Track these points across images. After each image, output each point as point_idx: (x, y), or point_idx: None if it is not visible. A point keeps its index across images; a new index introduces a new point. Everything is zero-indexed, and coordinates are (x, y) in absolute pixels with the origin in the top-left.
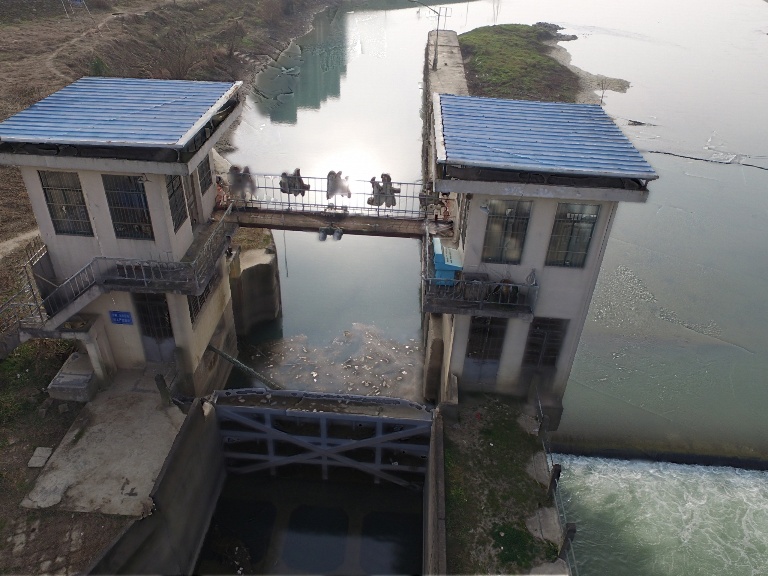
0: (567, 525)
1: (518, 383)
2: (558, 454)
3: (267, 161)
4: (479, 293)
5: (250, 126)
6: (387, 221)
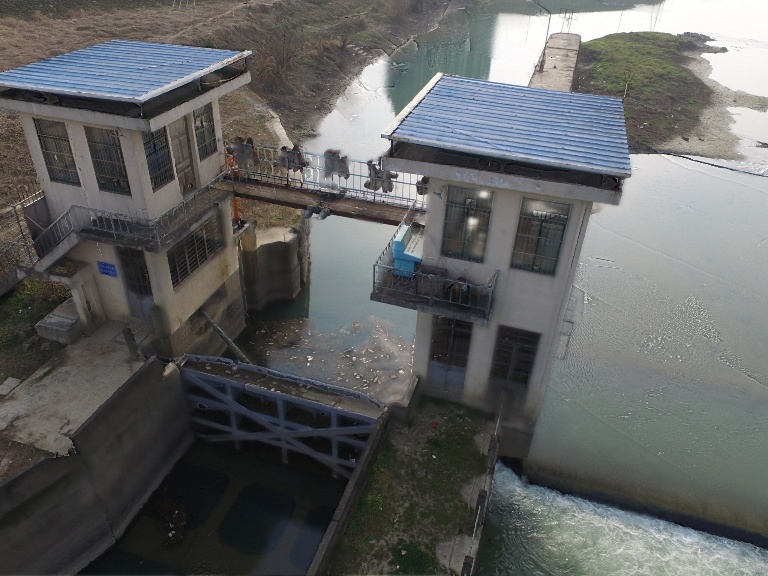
0: (465, 557)
1: (486, 397)
2: (542, 487)
3: (345, 149)
4: (433, 288)
5: (341, 115)
6: (381, 207)
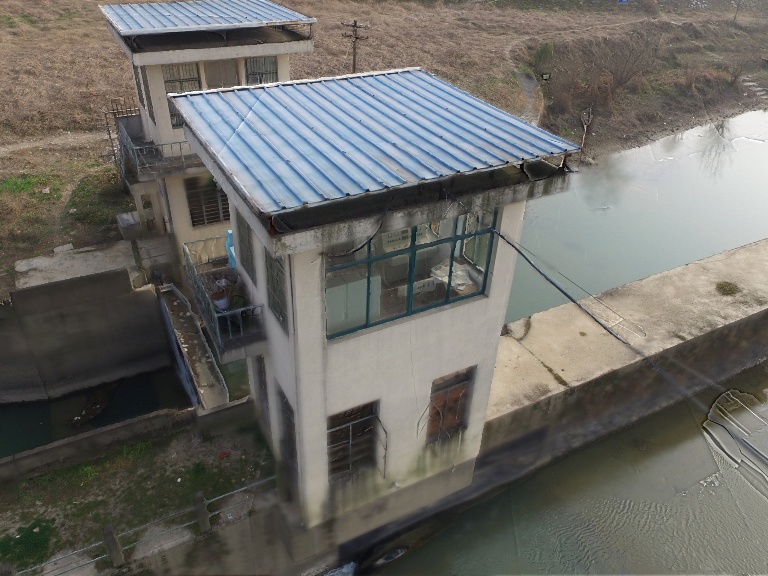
0: None
1: None
2: None
3: (610, 187)
4: None
5: (651, 153)
6: None
